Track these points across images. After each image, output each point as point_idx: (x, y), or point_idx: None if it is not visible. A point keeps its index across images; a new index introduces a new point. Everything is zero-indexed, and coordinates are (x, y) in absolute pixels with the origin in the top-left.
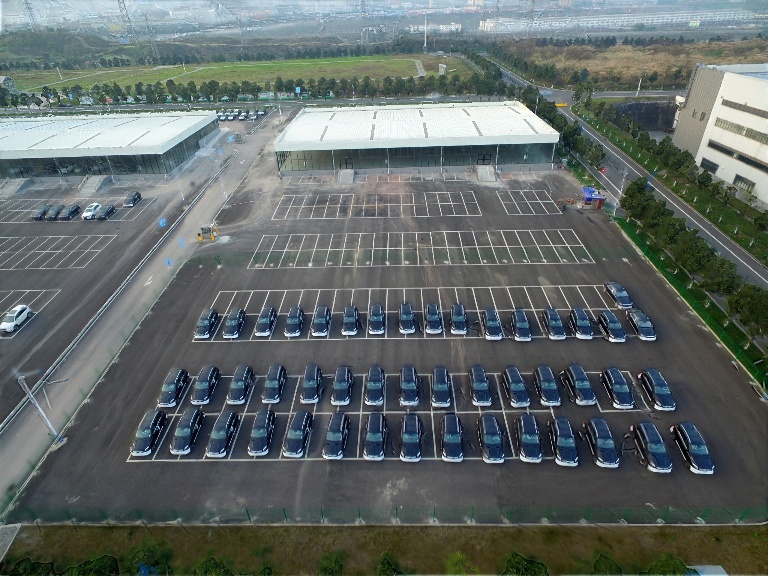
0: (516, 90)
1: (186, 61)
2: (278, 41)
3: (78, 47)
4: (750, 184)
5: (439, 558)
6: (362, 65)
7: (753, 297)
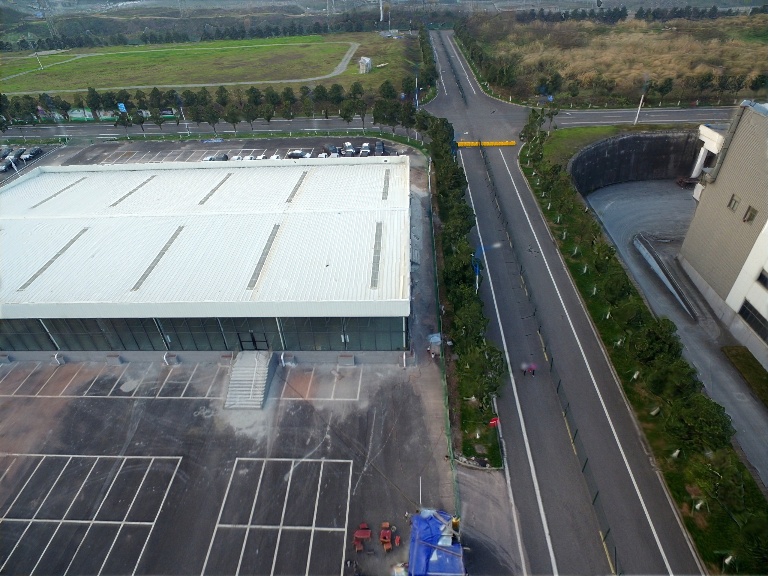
0: (428, 121)
1: (78, 44)
2: (226, 12)
3: None
4: None
5: None
6: (278, 53)
7: None
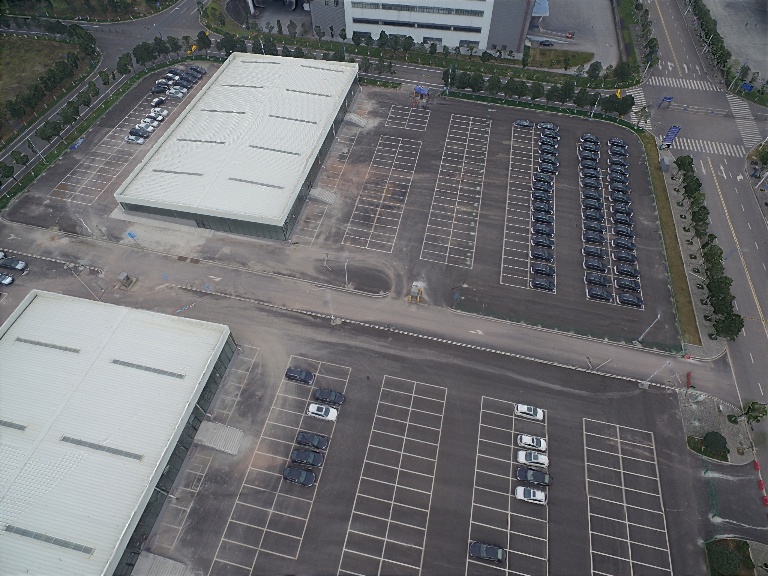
0: (180, 41)
1: None
2: None
3: None
4: (402, 37)
5: (667, 215)
6: None
7: (558, 90)
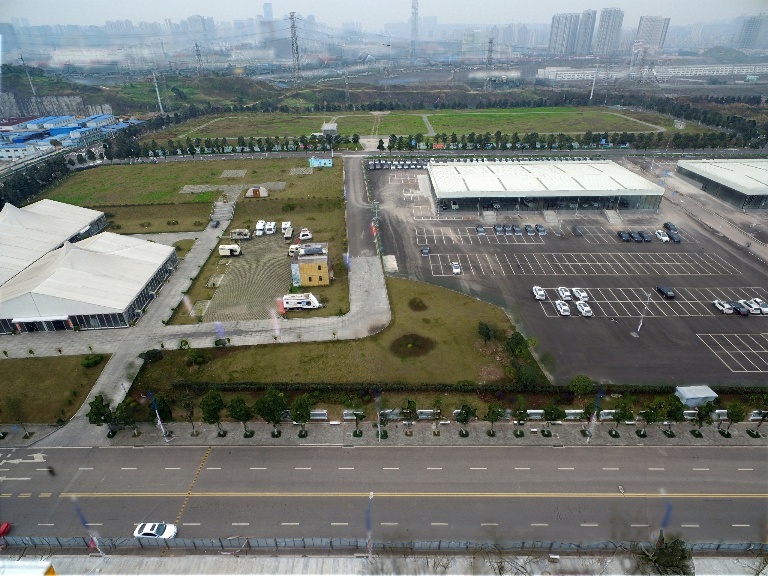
0: None
1: (391, 108)
2: (415, 88)
3: (260, 91)
4: None
5: None
6: (576, 117)
7: None
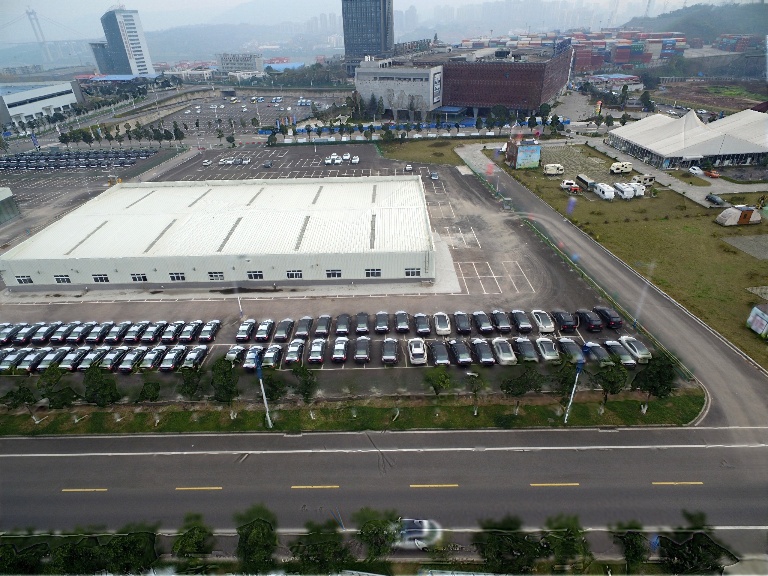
0: None
1: None
2: None
3: None
4: None
5: None
6: None
7: None
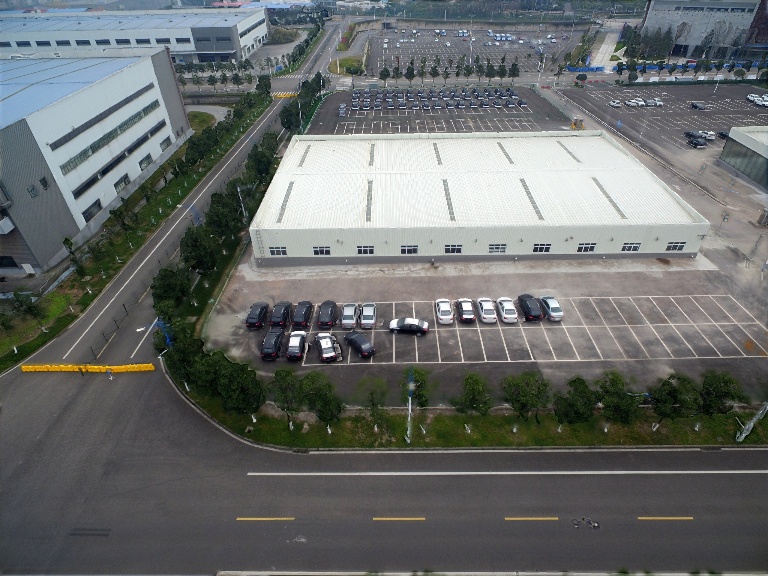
0: None
1: None
2: None
3: None
4: None
5: None
6: None
7: None
